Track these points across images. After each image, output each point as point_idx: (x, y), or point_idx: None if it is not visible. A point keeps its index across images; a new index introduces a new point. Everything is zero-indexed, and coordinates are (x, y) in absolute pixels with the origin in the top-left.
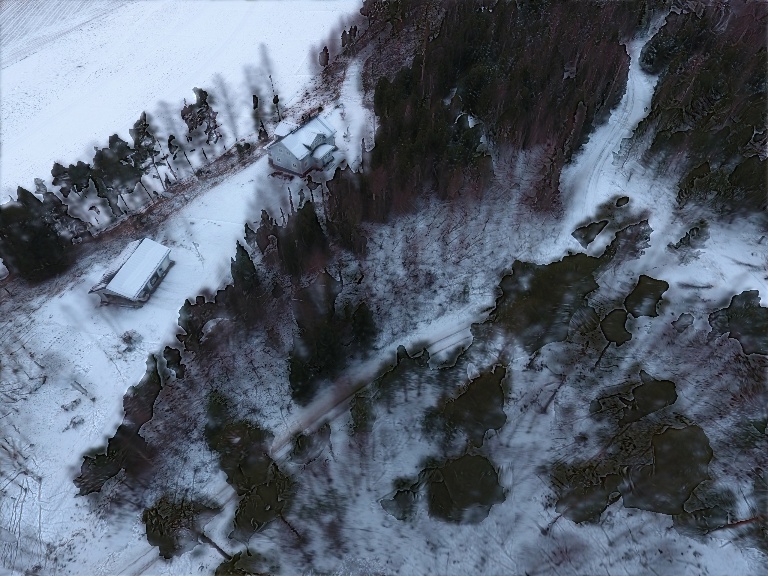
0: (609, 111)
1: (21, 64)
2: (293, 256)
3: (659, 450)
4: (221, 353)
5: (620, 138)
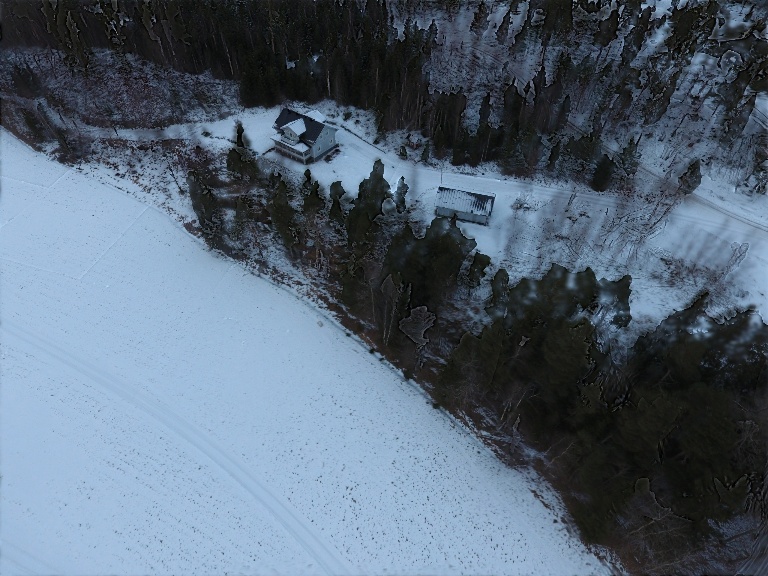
0: None
1: None
2: None
3: None
4: (526, 166)
5: None
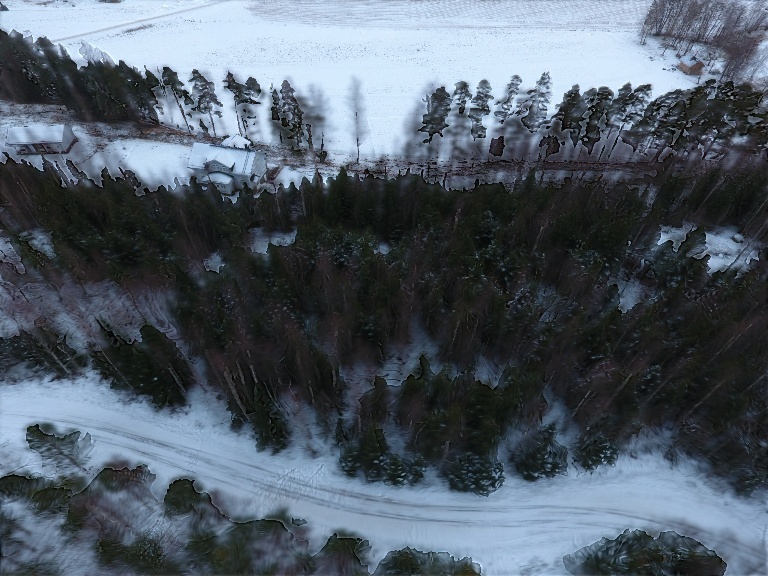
0: (272, 439)
1: (406, 32)
2: None
3: None
4: None
5: (214, 478)
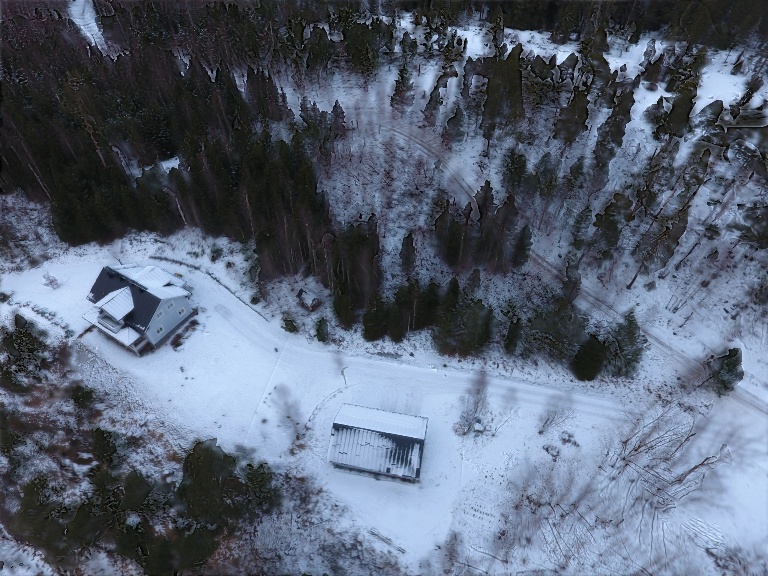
0: None
1: None
2: (412, 243)
3: (603, 61)
4: None
5: None
